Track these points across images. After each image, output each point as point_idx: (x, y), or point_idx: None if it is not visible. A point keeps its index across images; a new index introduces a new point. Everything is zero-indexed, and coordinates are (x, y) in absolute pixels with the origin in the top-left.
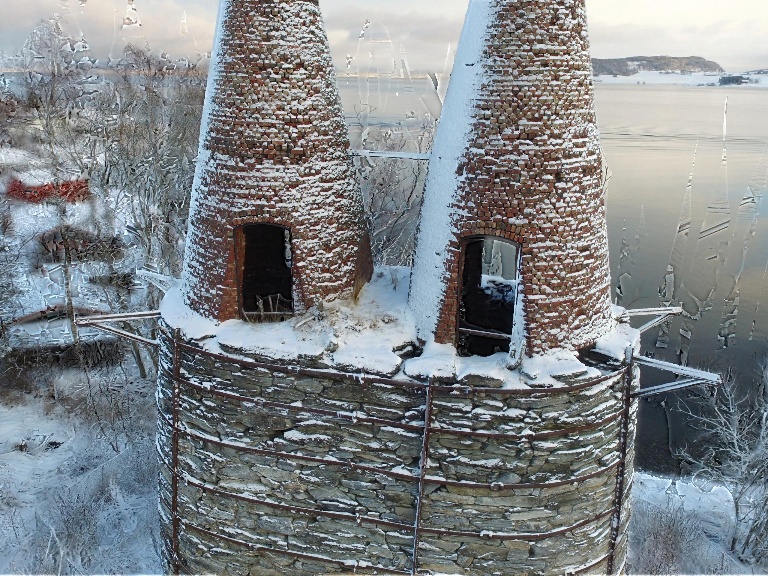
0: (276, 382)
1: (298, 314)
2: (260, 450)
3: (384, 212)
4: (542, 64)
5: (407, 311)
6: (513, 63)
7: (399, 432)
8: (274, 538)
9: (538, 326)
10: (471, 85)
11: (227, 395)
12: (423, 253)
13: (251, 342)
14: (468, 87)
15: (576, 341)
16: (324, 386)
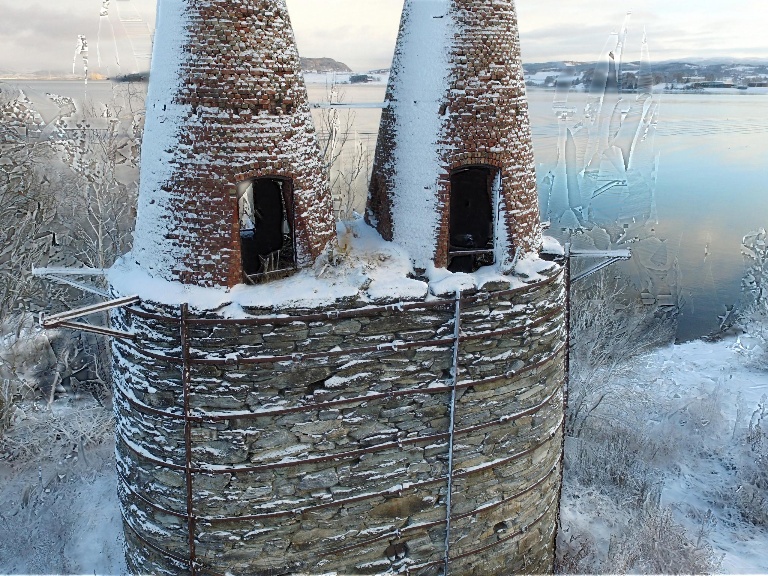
0: (313, 332)
1: (303, 267)
2: (301, 407)
3: None
4: (499, 17)
5: (396, 248)
6: (480, 15)
7: (433, 349)
8: (318, 494)
9: (518, 236)
10: (444, 35)
11: (259, 360)
12: (407, 191)
13: (282, 298)
14: (441, 36)
15: (537, 245)
16: (362, 324)
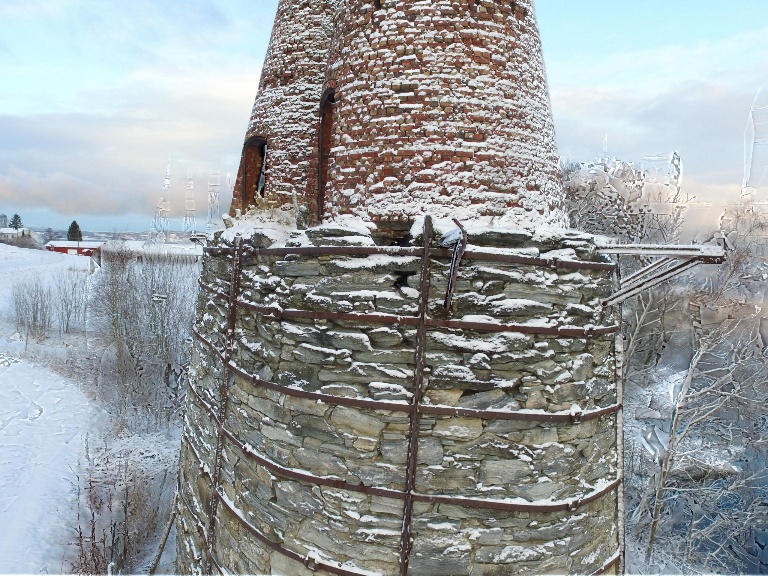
0: None
1: None
2: None
3: (732, 305)
4: None
5: None
6: None
7: None
8: None
9: (333, 185)
10: None
11: None
12: None
13: None
14: None
15: (375, 209)
16: None
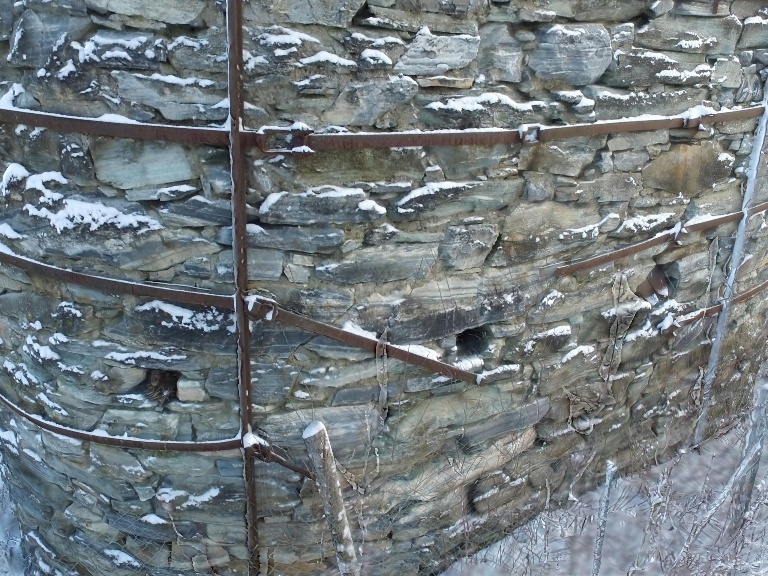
0: None
1: None
2: None
3: None
4: None
5: None
6: None
7: None
8: (573, 91)
9: None
10: None
11: None
12: None
13: None
14: None
15: None
16: None
